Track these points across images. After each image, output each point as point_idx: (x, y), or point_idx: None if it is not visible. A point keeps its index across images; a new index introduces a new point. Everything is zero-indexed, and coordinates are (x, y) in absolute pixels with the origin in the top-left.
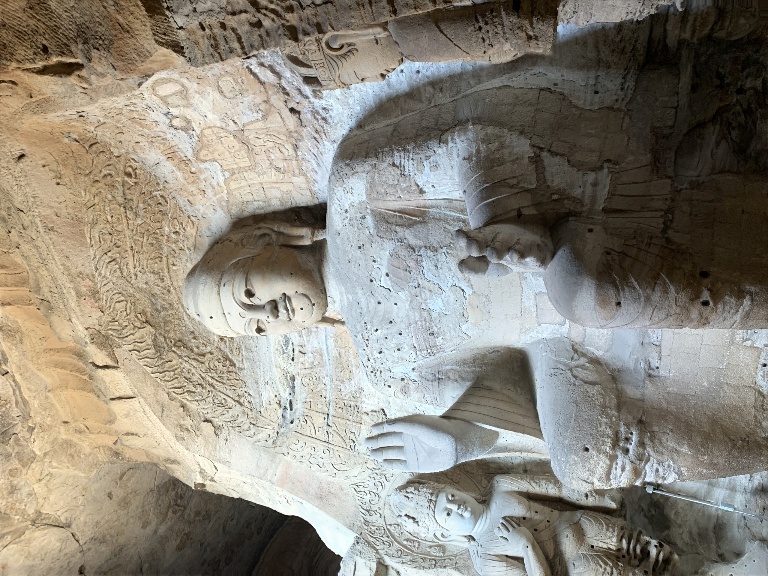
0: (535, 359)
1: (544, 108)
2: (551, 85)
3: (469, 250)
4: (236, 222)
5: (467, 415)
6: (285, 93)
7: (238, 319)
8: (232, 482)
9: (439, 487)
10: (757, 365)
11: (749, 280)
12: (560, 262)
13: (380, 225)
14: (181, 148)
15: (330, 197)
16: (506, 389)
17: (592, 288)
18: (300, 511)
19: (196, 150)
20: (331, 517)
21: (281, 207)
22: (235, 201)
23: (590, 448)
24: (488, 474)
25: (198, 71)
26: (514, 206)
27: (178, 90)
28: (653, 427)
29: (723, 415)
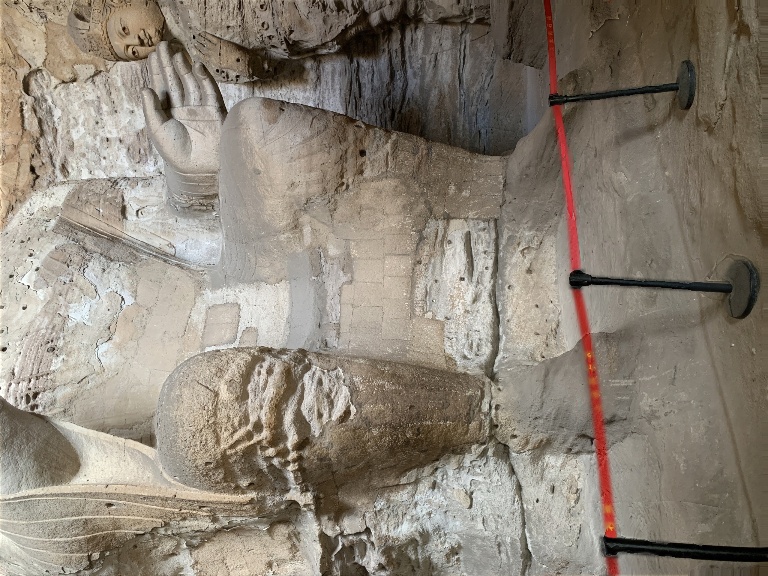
0: None
1: None
2: None
3: (159, 43)
4: None
5: None
6: (37, 149)
7: None
8: None
9: None
10: (443, 338)
11: None
12: None
13: (62, 226)
14: None
15: None
16: None
17: None
18: None
19: None
20: None
21: None
22: None
23: None
24: None
25: None
26: None
27: None
28: None
29: (410, 363)
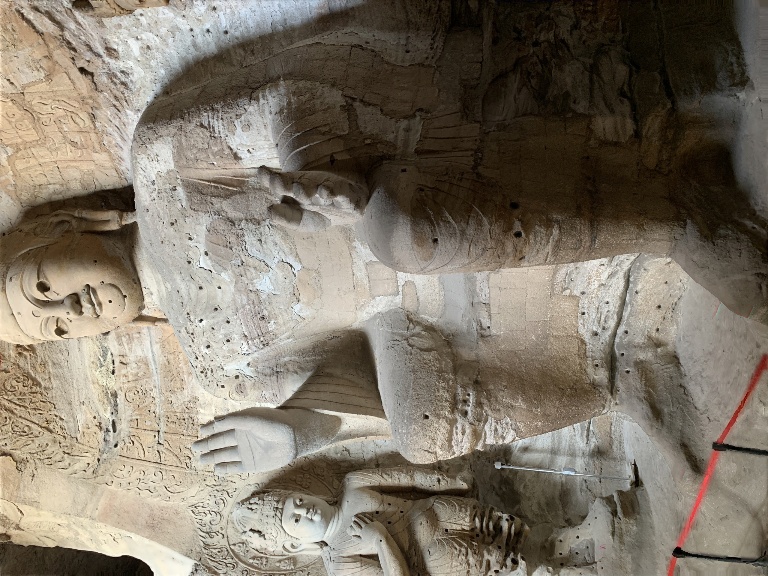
0: (373, 337)
1: (356, 63)
2: (362, 43)
3: (272, 185)
4: (29, 211)
5: (306, 403)
6: (71, 48)
7: (31, 319)
8: (43, 527)
9: (286, 493)
10: (577, 314)
11: (555, 209)
12: (375, 203)
13: (193, 197)
14: None
15: (133, 167)
16: (347, 374)
17: (407, 225)
18: (130, 548)
19: None
20: (164, 546)
21: (83, 191)
22: (25, 185)
23: (429, 415)
24: (339, 474)
25: None
26: (326, 152)
27: None
28: (488, 386)
29: (552, 366)
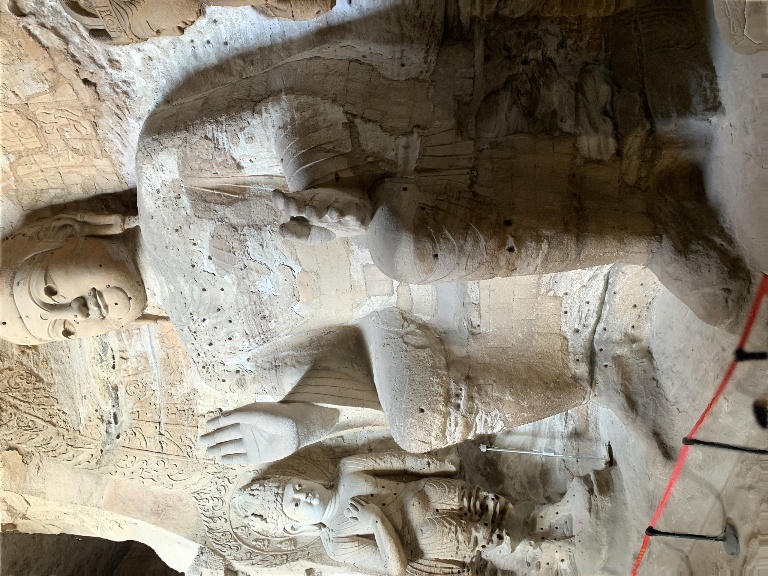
0: (369, 333)
1: (355, 78)
2: (360, 57)
3: (287, 209)
4: (30, 214)
5: (306, 397)
6: (75, 61)
7: (39, 322)
8: (50, 516)
9: (285, 479)
10: (560, 313)
11: (545, 225)
12: (379, 220)
13: (197, 204)
14: None
15: (138, 176)
16: (344, 368)
17: (410, 242)
18: (135, 534)
19: None
20: (170, 532)
21: (84, 195)
22: (26, 189)
23: (425, 409)
24: (334, 459)
25: None
26: (331, 170)
27: None
28: (479, 381)
29: (537, 362)
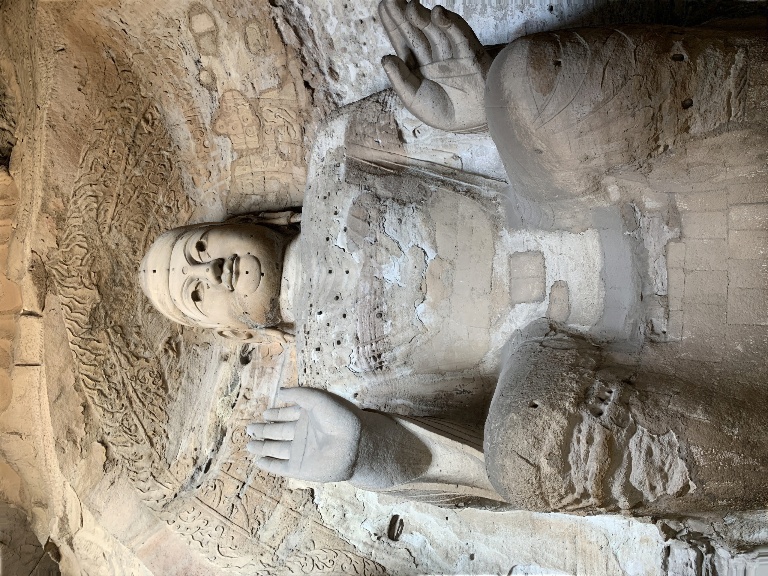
0: None
1: None
2: None
3: None
4: (230, 218)
5: (392, 413)
6: (303, 61)
7: (179, 276)
8: (91, 552)
9: None
10: None
11: (740, 34)
12: None
13: (351, 171)
14: (202, 112)
15: (312, 147)
16: (464, 424)
17: (525, 47)
18: None
19: (214, 119)
20: None
21: (276, 205)
22: (236, 192)
23: (539, 402)
24: None
25: (229, 5)
26: None
27: (210, 29)
28: (647, 387)
29: None
